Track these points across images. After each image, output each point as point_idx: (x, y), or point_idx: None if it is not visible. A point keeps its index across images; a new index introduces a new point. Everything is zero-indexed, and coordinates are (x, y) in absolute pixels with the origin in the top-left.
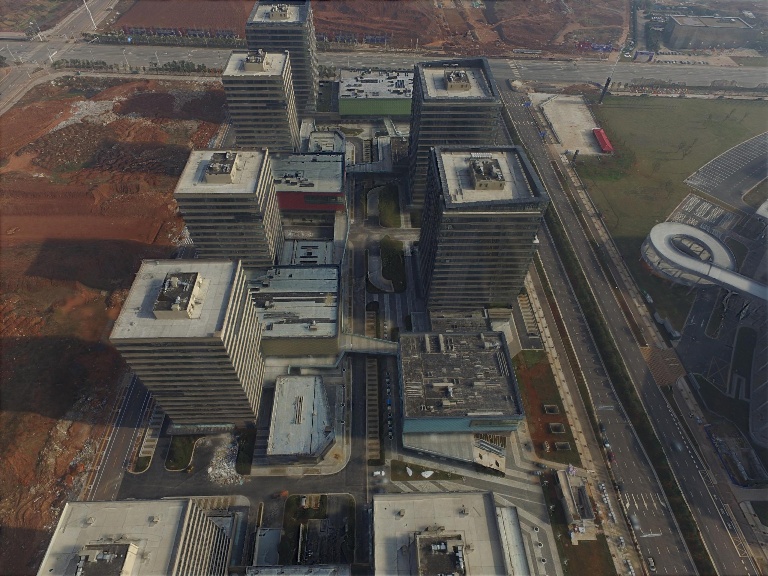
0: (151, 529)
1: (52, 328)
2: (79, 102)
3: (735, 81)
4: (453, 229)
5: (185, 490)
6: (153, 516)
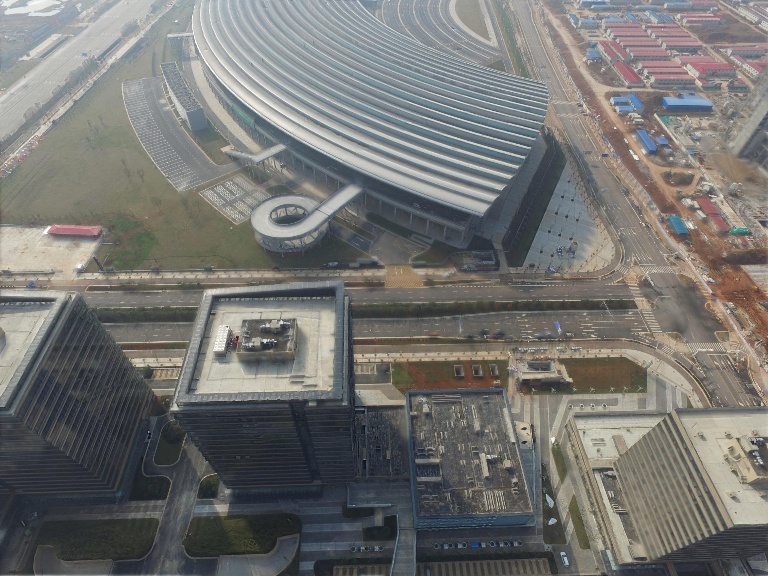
0: None
1: None
2: None
3: (37, 103)
4: None
5: None
6: None
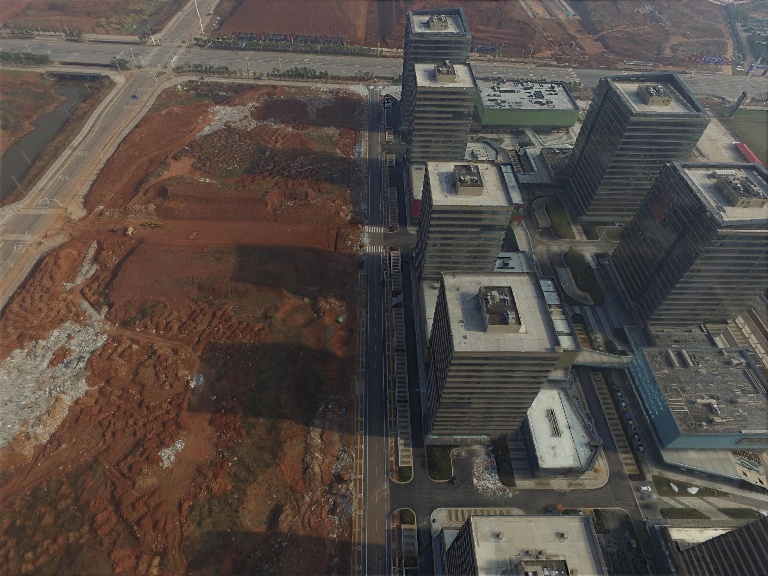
0: (563, 545)
1: (277, 335)
2: (215, 107)
3: None
4: (719, 246)
5: (457, 501)
6: (559, 532)
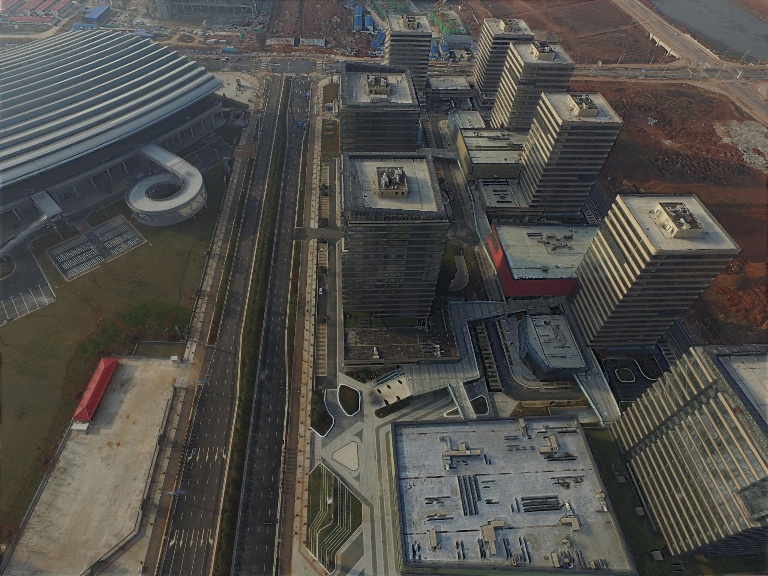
0: None
1: (644, 158)
2: None
3: None
4: None
5: None
6: None
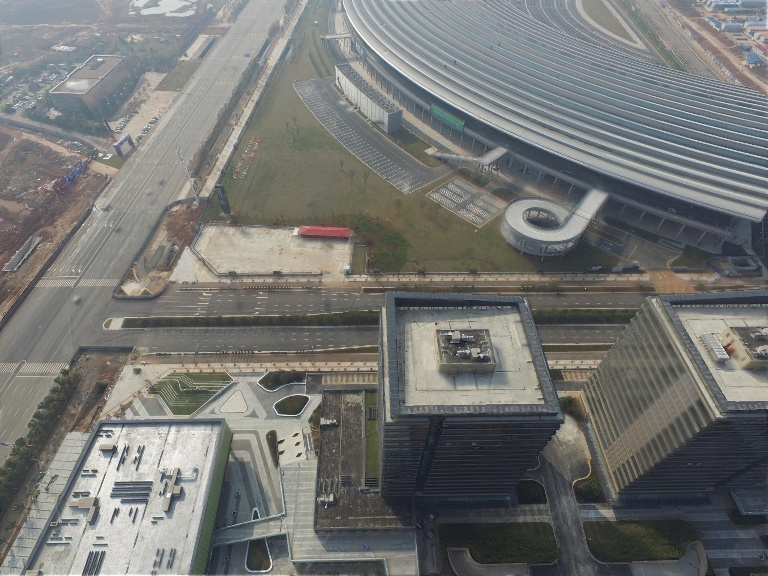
0: None
1: None
2: None
3: (226, 104)
4: None
5: None
6: None
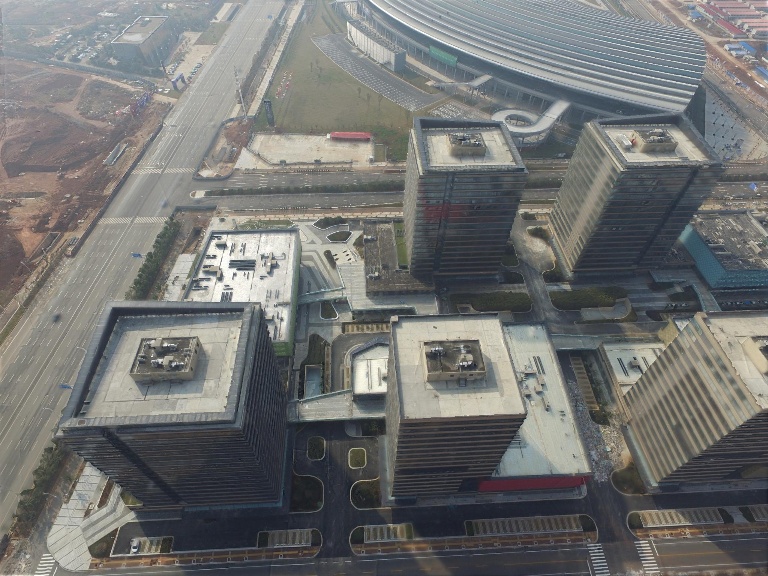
0: None
1: None
2: None
3: (258, 51)
4: None
5: None
6: None
